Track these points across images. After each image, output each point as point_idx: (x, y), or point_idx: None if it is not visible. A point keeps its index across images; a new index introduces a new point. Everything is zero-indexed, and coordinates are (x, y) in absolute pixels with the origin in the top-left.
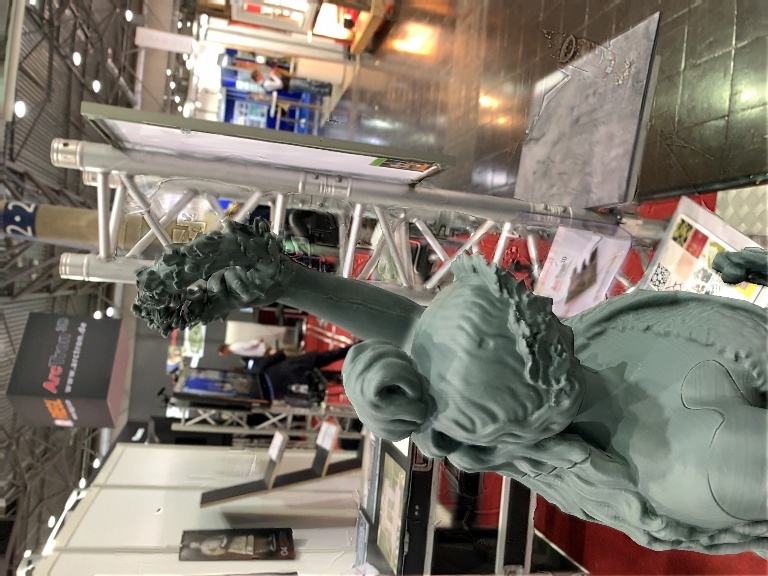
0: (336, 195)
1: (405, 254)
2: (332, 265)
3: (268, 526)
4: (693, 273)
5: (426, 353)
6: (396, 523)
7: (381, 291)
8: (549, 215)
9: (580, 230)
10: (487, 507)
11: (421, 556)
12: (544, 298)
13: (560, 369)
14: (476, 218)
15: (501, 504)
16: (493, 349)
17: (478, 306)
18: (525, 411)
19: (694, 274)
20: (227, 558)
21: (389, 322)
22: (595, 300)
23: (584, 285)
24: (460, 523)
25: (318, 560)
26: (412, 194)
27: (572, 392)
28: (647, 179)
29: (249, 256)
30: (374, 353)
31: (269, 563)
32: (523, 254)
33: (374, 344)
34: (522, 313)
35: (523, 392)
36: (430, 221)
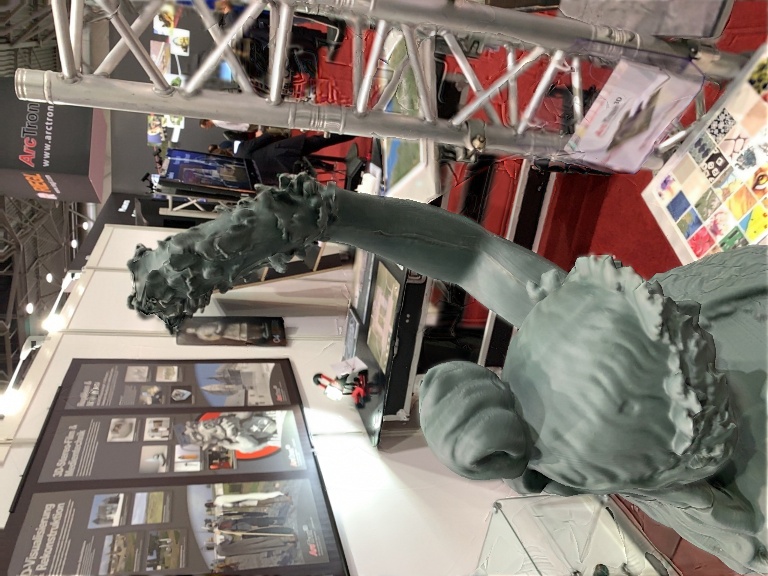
0: (355, 7)
1: (428, 76)
2: (344, 90)
3: (260, 315)
4: (765, 128)
5: (538, 399)
6: (387, 330)
7: (441, 216)
8: (612, 44)
9: (644, 65)
10: (475, 316)
11: (409, 358)
12: (692, 306)
13: (719, 439)
14: (522, 41)
15: (489, 315)
16: (638, 415)
17: (624, 352)
18: (654, 471)
19: (766, 129)
20: (222, 343)
21: (448, 257)
22: (642, 148)
23: (634, 131)
24: (448, 330)
25: (308, 347)
26: (450, 10)
27: (723, 459)
28: (742, 4)
29: (293, 242)
30: (471, 401)
31: (262, 350)
32: (564, 80)
33: (466, 377)
34: (685, 368)
35: (661, 459)
36: (461, 34)
